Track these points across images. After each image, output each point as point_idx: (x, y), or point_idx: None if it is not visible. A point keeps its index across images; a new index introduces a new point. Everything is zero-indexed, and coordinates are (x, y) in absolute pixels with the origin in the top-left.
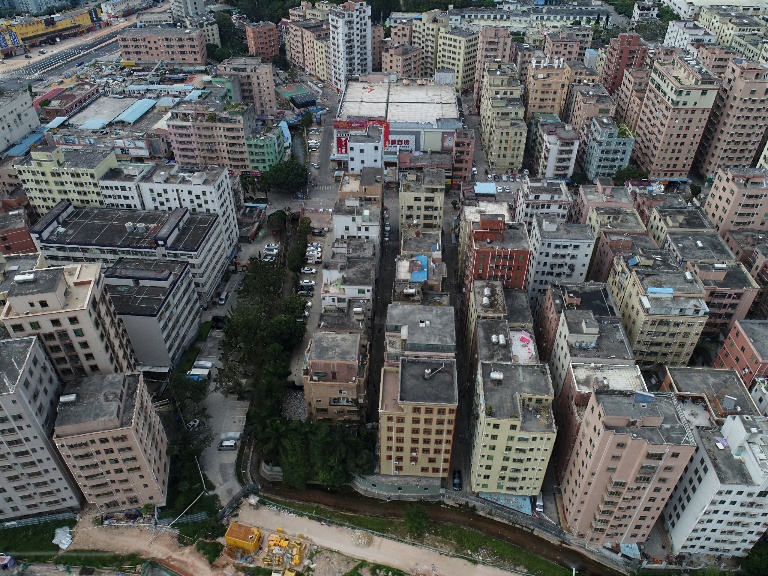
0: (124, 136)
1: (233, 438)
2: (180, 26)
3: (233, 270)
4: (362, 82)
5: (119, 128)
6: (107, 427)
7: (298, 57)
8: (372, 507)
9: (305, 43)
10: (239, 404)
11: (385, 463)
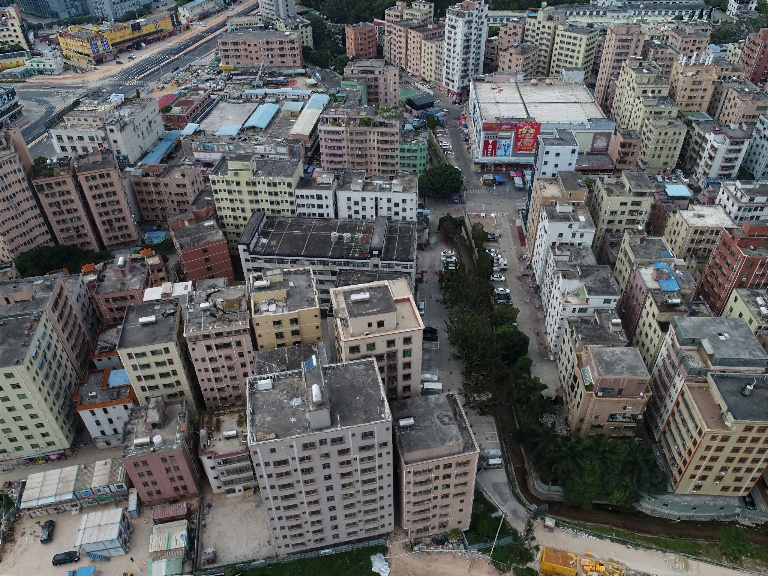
0: (264, 142)
1: (495, 456)
2: (272, 29)
3: (419, 279)
4: (487, 82)
5: (251, 134)
6: (451, 452)
7: (399, 58)
8: (664, 528)
9: (410, 44)
10: (483, 419)
11: (685, 482)
